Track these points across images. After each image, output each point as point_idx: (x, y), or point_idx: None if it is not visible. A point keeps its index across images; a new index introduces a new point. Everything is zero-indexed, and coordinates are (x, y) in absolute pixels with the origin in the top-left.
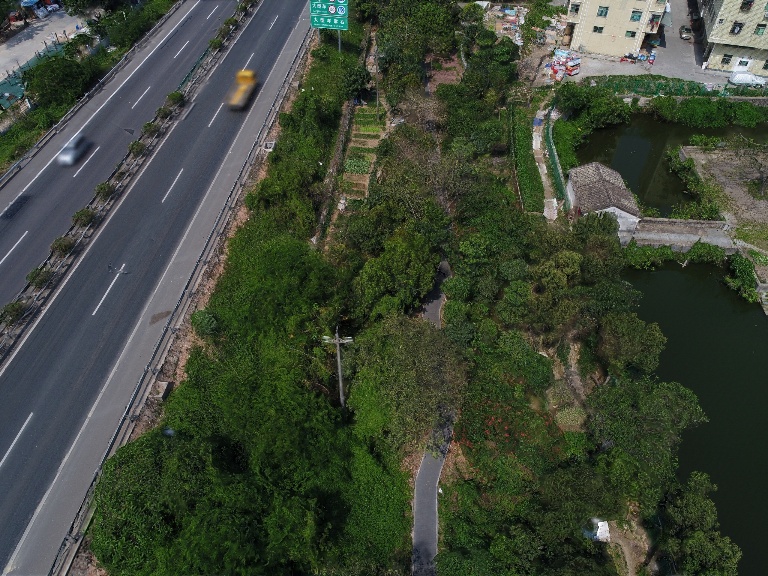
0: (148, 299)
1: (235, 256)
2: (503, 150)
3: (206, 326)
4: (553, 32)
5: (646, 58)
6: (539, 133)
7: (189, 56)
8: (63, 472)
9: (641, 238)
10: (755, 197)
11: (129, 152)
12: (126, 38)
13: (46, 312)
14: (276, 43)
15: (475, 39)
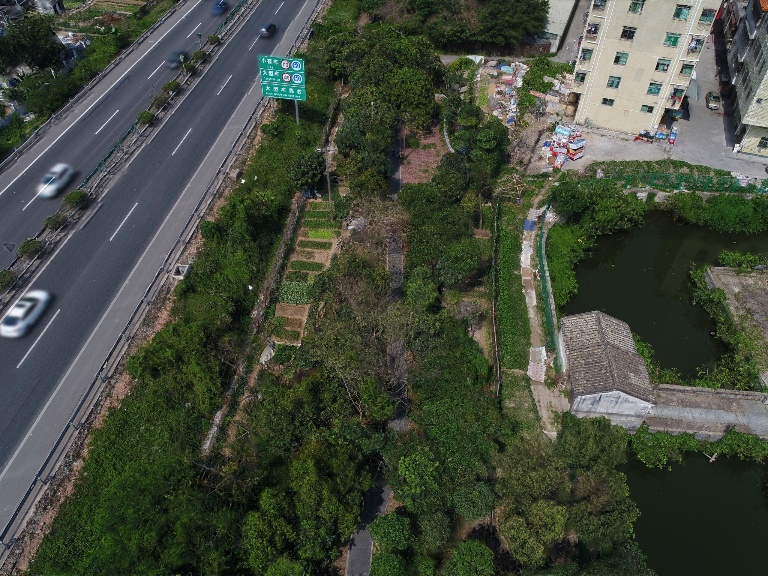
0: None
1: (95, 462)
2: (483, 267)
3: None
4: (555, 98)
5: (665, 136)
6: (530, 242)
7: (113, 132)
8: None
9: (655, 416)
10: None
11: None
12: (44, 107)
13: None
14: (221, 114)
15: (458, 114)
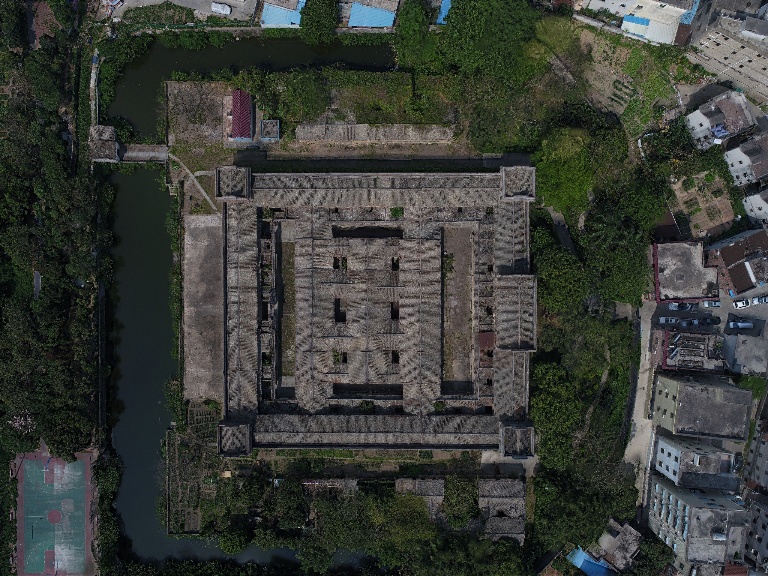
0: None
1: None
2: None
3: None
4: None
5: None
6: (95, 71)
7: None
8: None
9: (129, 156)
10: (190, 122)
11: None
12: None
13: None
14: None
15: None
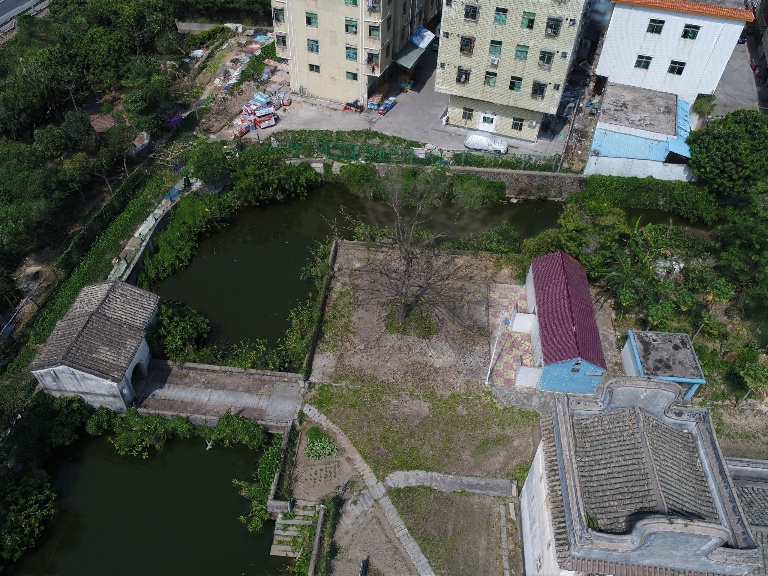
0: None
1: None
2: None
3: None
4: (288, 67)
5: (377, 107)
6: (162, 211)
7: None
8: None
9: (165, 397)
10: (388, 328)
11: None
12: None
13: None
14: None
15: None
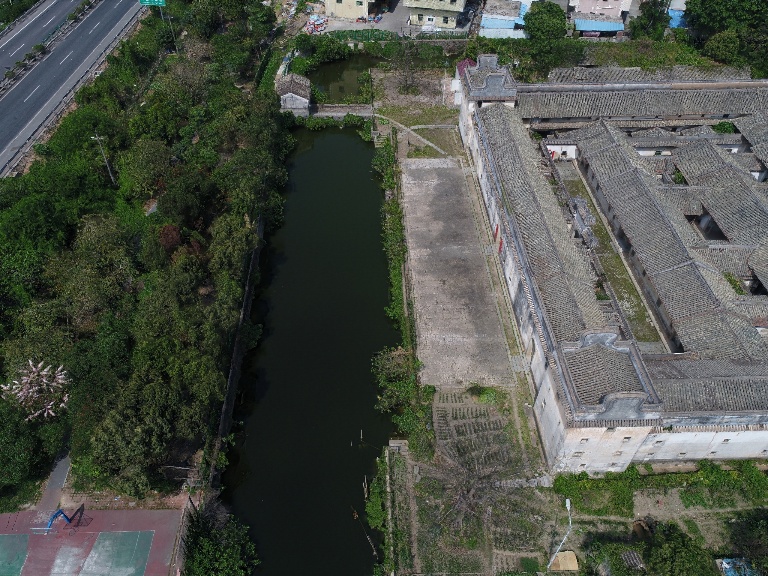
0: (11, 142)
1: (65, 125)
2: None
3: (41, 149)
4: (319, 5)
5: (373, 19)
6: (285, 65)
7: None
8: None
9: None
10: (400, 93)
11: (5, 77)
12: (10, 16)
13: None
14: (117, 16)
15: None
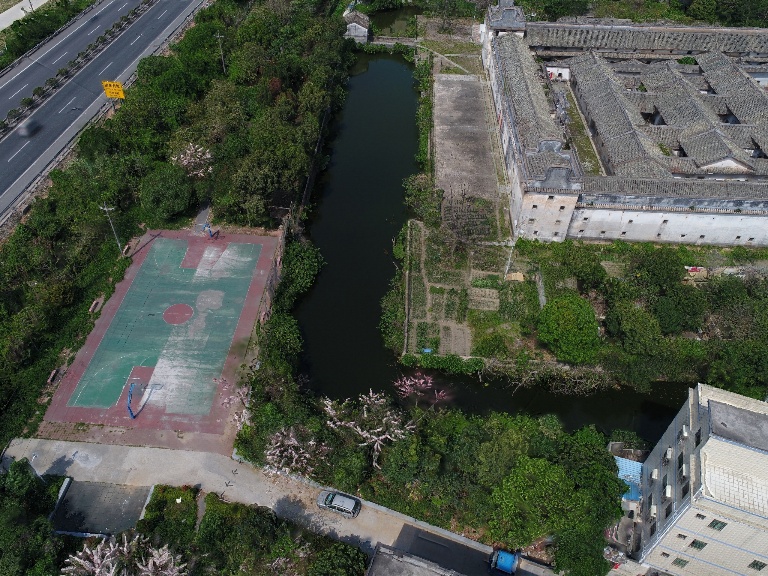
0: (152, 42)
1: (188, 35)
2: None
3: (175, 47)
4: None
5: None
6: (349, 10)
7: None
8: (125, 72)
9: None
10: (439, 33)
11: (142, 2)
12: None
13: (113, 43)
14: None
15: None
